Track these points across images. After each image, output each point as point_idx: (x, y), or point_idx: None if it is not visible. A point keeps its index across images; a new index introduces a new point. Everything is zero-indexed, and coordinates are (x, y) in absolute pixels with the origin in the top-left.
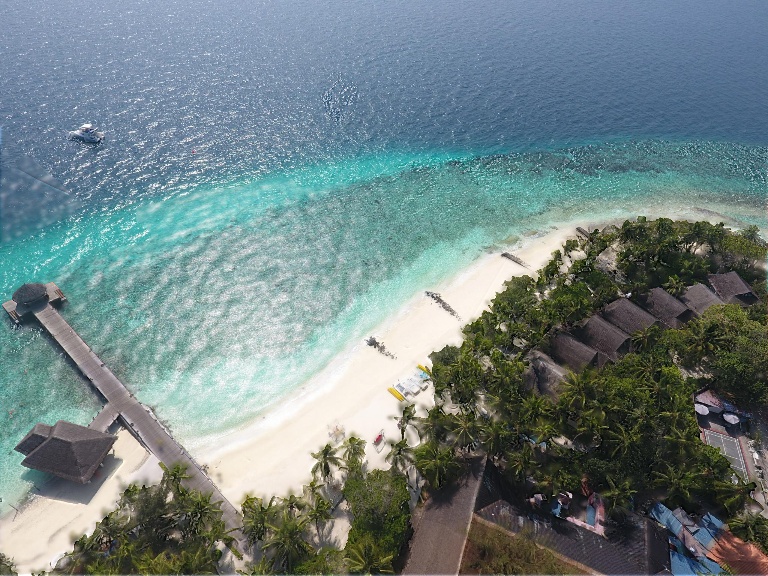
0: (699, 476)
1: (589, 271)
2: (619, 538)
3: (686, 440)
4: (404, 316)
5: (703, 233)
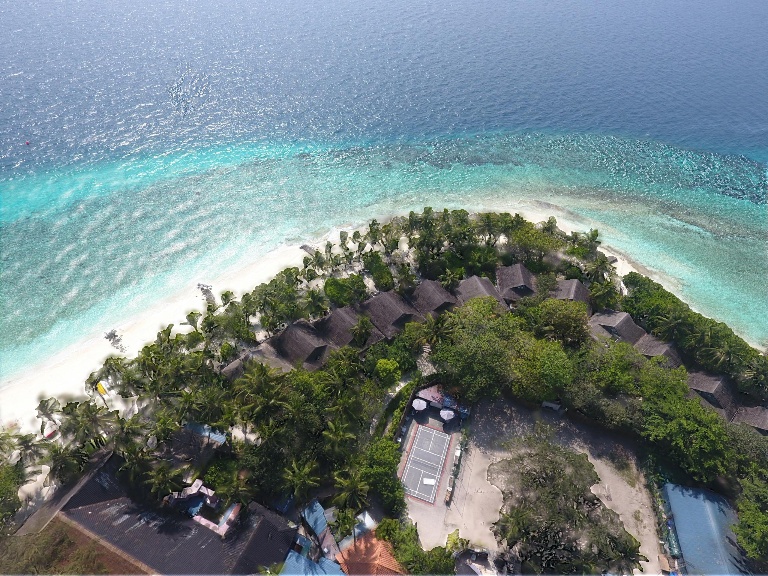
0: (345, 473)
1: (373, 263)
2: (232, 538)
3: (333, 435)
4: (160, 309)
5: (495, 225)
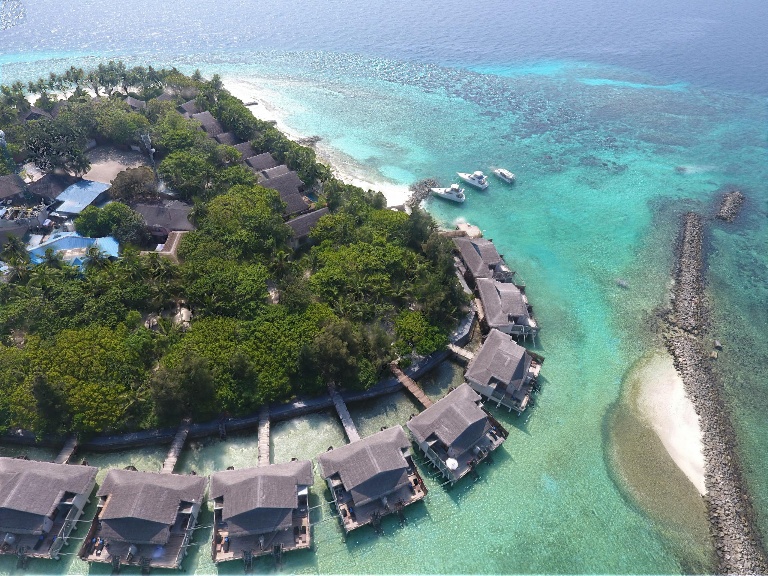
0: None
1: None
2: None
3: None
4: None
5: (157, 73)
